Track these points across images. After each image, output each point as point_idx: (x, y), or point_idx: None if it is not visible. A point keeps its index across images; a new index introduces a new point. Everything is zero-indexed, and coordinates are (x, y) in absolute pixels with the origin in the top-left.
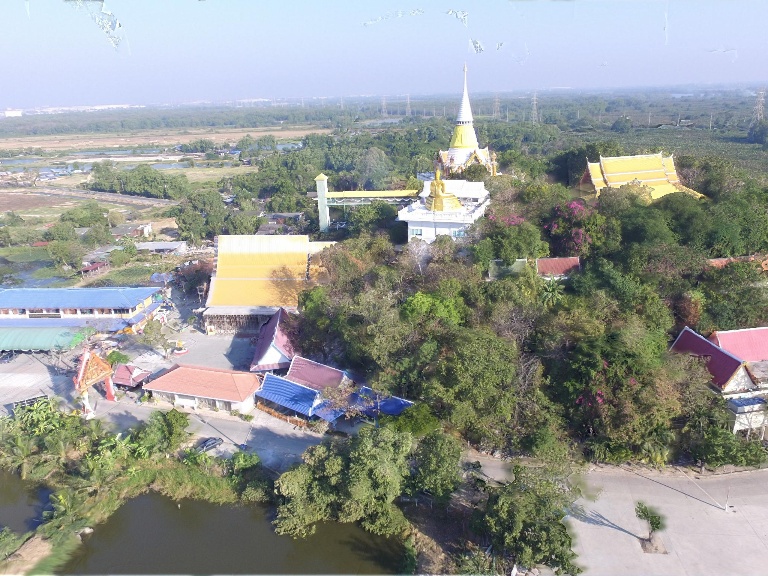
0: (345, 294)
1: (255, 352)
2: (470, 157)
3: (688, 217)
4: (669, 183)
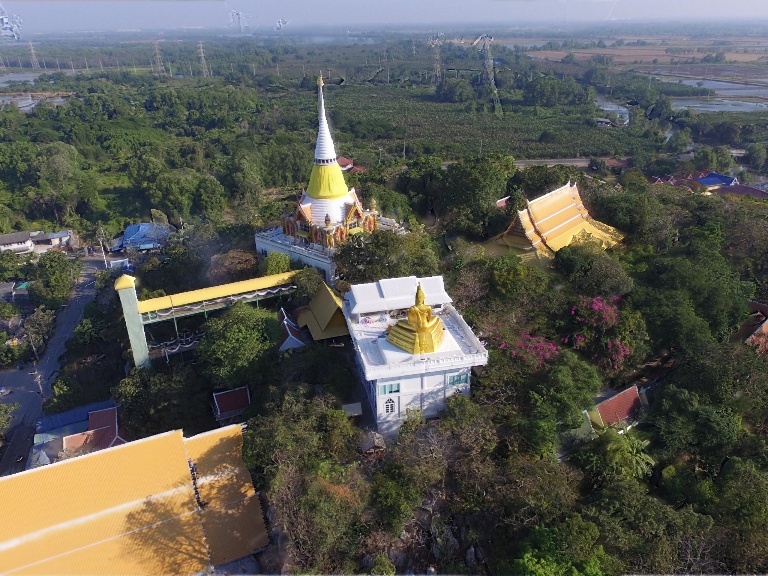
0: (350, 568)
1: None
2: (349, 212)
3: (708, 295)
4: (584, 219)
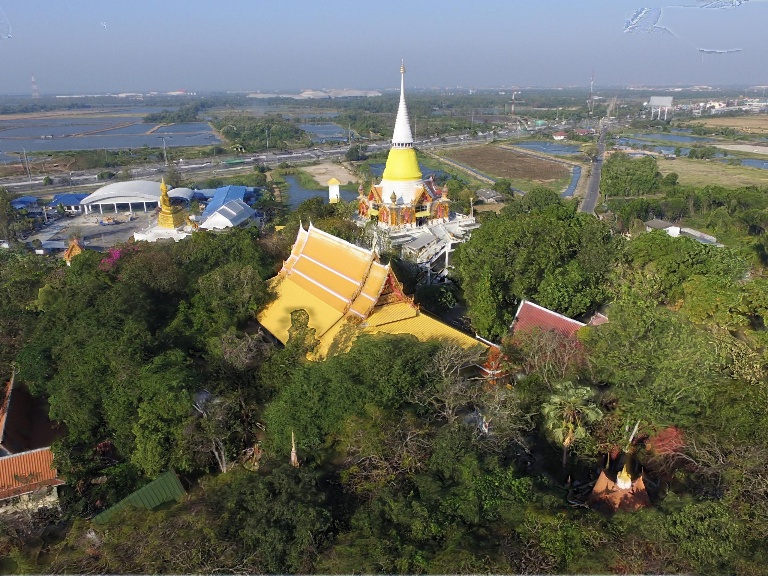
0: None
1: None
2: None
3: None
4: (343, 310)
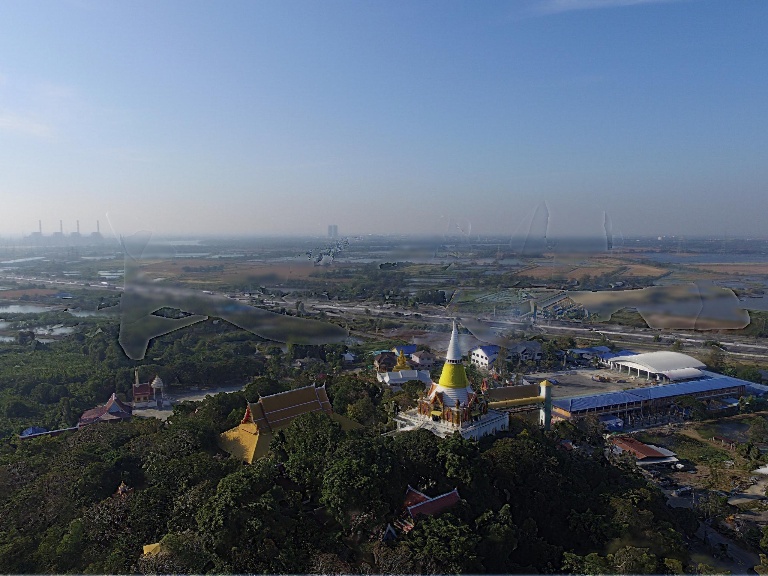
0: None
1: None
2: None
3: None
4: None
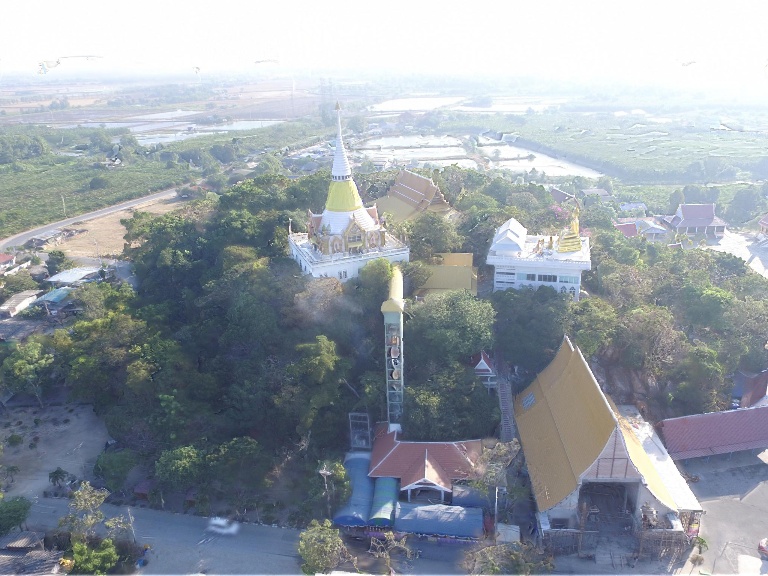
0: None
1: (714, 472)
2: (376, 214)
3: None
4: None
